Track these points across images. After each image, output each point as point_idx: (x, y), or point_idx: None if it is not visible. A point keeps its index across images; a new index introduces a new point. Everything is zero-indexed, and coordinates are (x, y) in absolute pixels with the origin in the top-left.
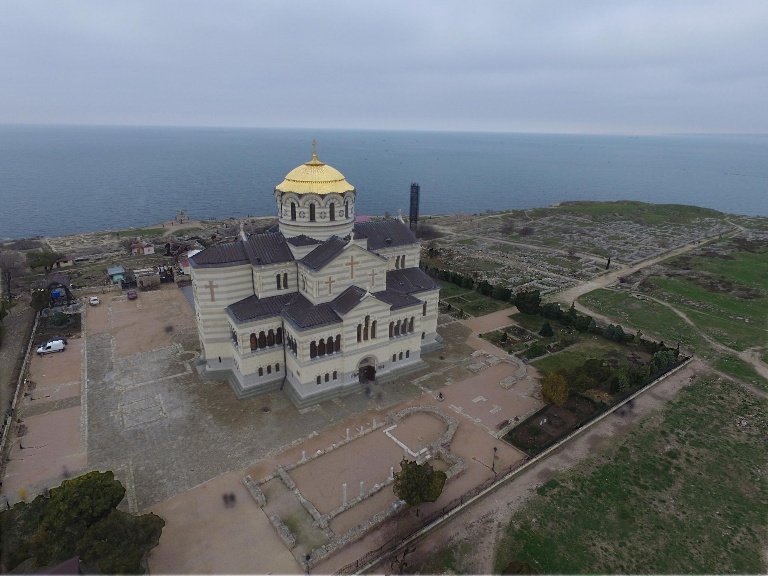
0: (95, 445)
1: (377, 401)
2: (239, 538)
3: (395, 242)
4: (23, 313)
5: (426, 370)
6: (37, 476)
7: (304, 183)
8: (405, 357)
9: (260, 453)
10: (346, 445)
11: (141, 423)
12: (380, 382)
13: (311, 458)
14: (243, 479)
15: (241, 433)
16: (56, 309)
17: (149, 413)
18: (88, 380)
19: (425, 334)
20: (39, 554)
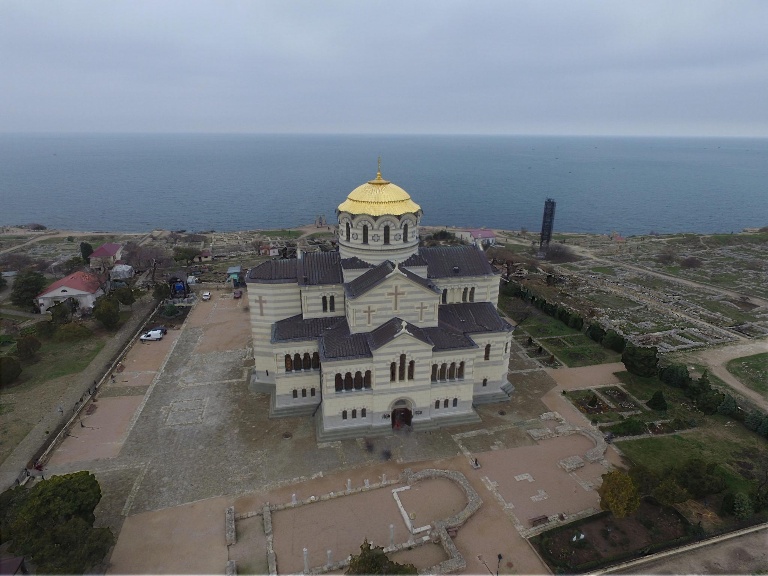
0: (133, 437)
1: (402, 451)
2: (191, 575)
3: (464, 272)
4: (152, 300)
5: (476, 425)
6: (78, 456)
7: (360, 203)
8: (452, 405)
9: (258, 483)
10: (345, 497)
11: (179, 424)
12: (416, 429)
13: (302, 503)
14: (226, 509)
15: (253, 456)
16: (175, 300)
17: (190, 415)
18: (163, 371)
19: (487, 381)
20: (13, 540)
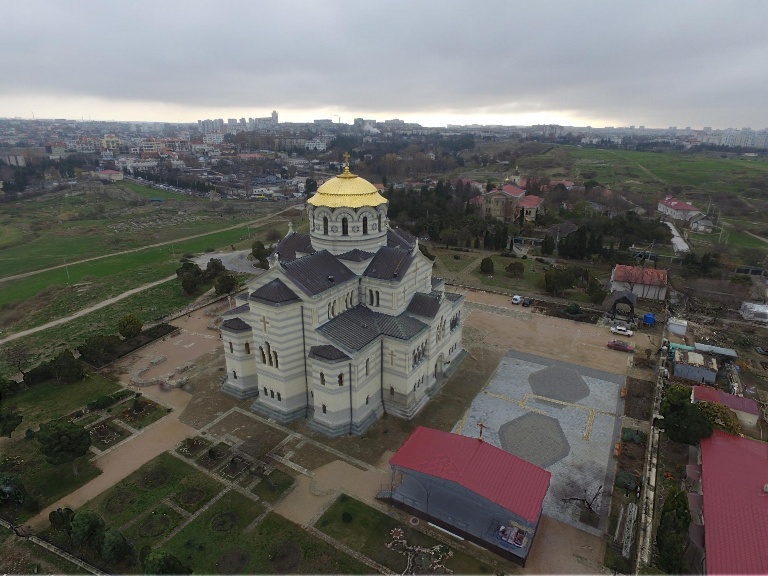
0: None
1: None
2: None
3: None
4: None
5: None
6: None
7: None
8: None
9: None
10: None
11: None
12: None
13: None
14: None
15: None
16: None
17: None
18: None
19: None
20: None
